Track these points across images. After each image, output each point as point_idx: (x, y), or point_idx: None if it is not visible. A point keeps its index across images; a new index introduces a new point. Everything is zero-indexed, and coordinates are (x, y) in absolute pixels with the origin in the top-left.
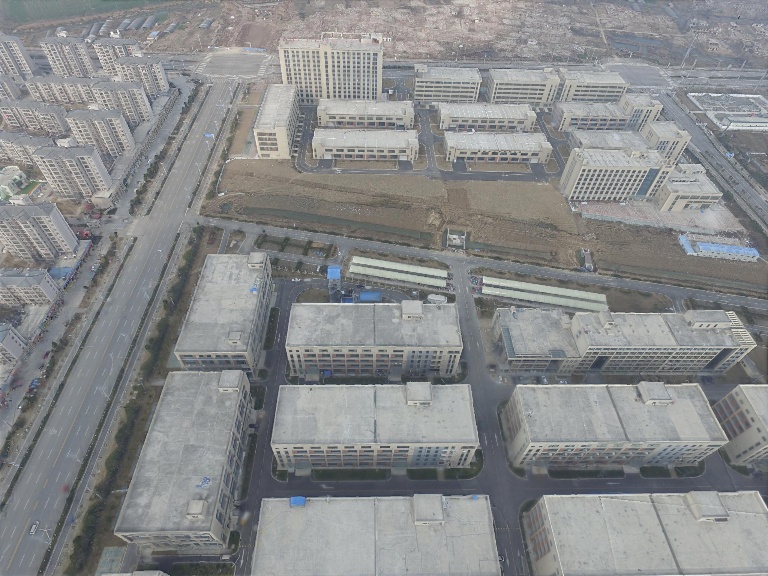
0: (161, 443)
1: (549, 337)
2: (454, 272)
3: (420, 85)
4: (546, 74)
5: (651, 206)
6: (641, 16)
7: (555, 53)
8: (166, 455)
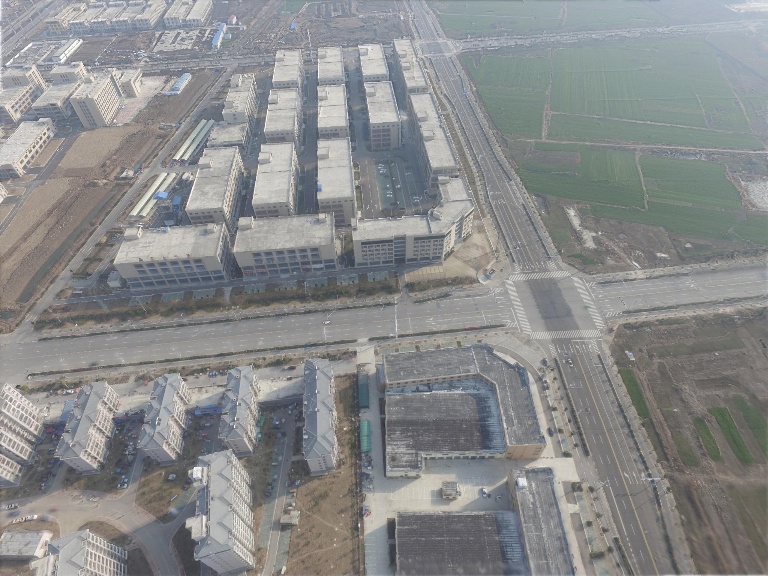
0: (284, 243)
1: (232, 130)
2: None
3: None
4: None
5: (131, 99)
6: None
7: None
8: (292, 239)
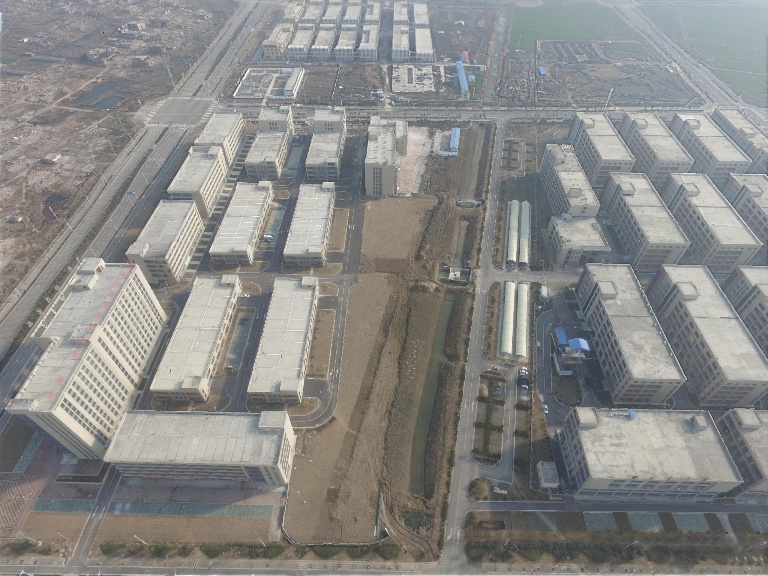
0: None
1: (582, 228)
2: (502, 280)
3: (171, 260)
4: (197, 154)
5: (401, 157)
6: (44, 75)
7: (95, 148)
8: None
